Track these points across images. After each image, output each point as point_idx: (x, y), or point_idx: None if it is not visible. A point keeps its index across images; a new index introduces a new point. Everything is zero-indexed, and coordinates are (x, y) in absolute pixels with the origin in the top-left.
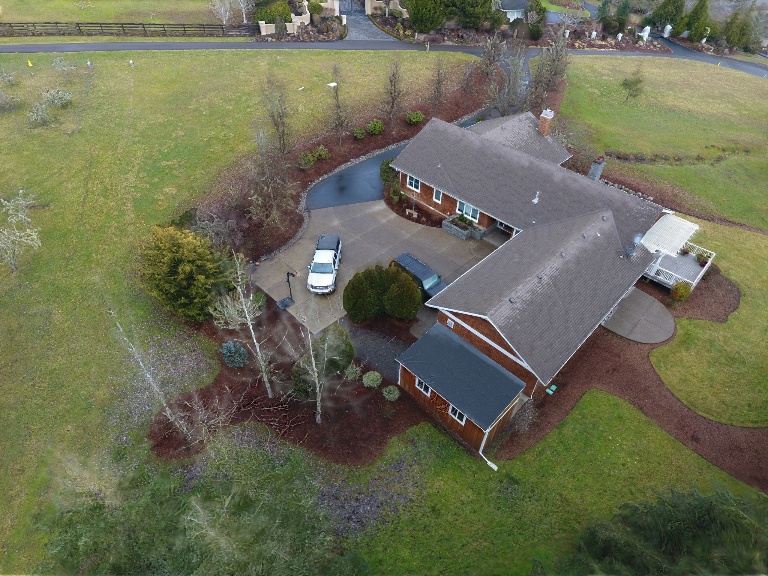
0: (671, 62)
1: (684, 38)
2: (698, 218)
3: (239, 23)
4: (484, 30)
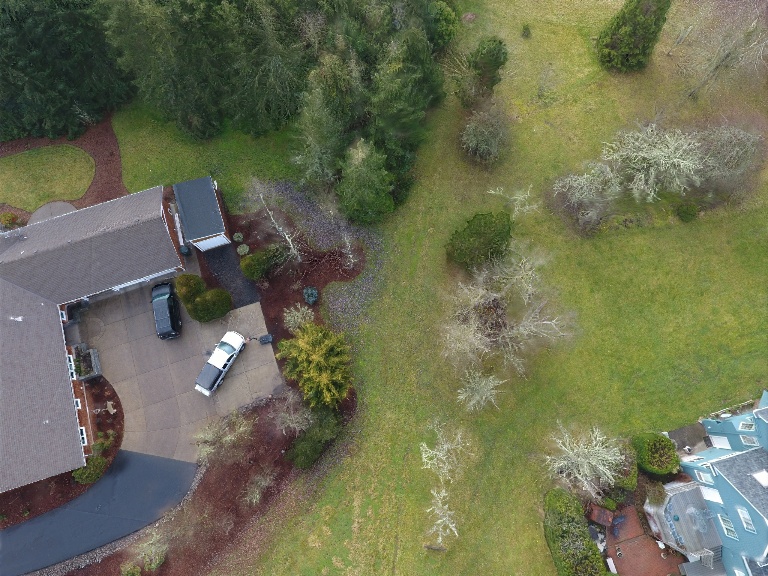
0: None
1: None
2: None
3: None
4: None
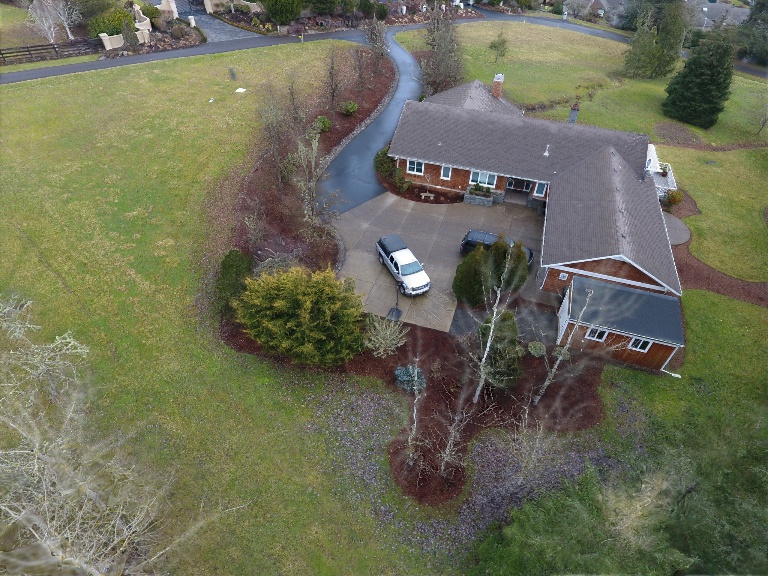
0: (495, 24)
1: (486, 3)
2: None
3: (64, 40)
4: (337, 15)
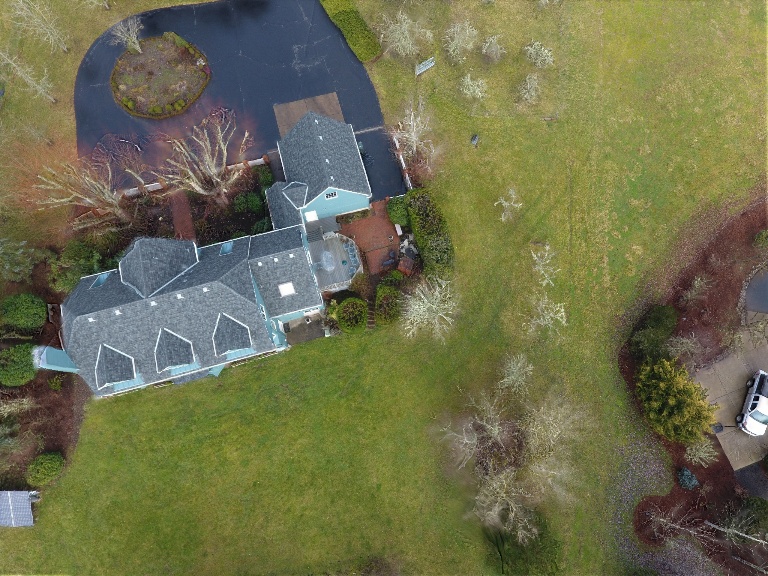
0: None
1: None
2: None
3: None
4: None
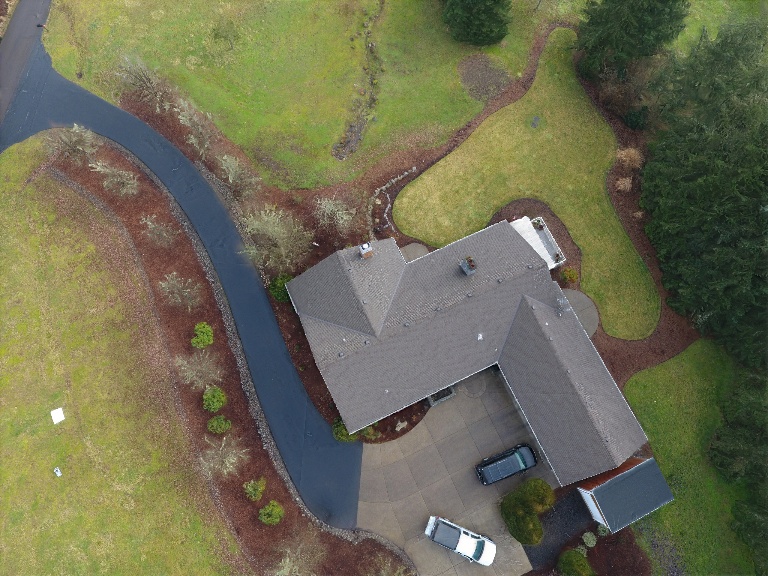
0: None
1: None
2: (451, 152)
3: None
4: None
